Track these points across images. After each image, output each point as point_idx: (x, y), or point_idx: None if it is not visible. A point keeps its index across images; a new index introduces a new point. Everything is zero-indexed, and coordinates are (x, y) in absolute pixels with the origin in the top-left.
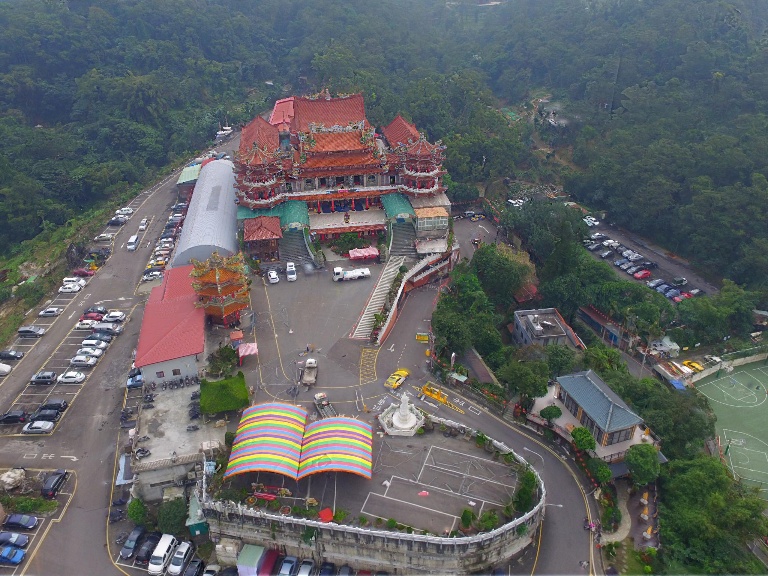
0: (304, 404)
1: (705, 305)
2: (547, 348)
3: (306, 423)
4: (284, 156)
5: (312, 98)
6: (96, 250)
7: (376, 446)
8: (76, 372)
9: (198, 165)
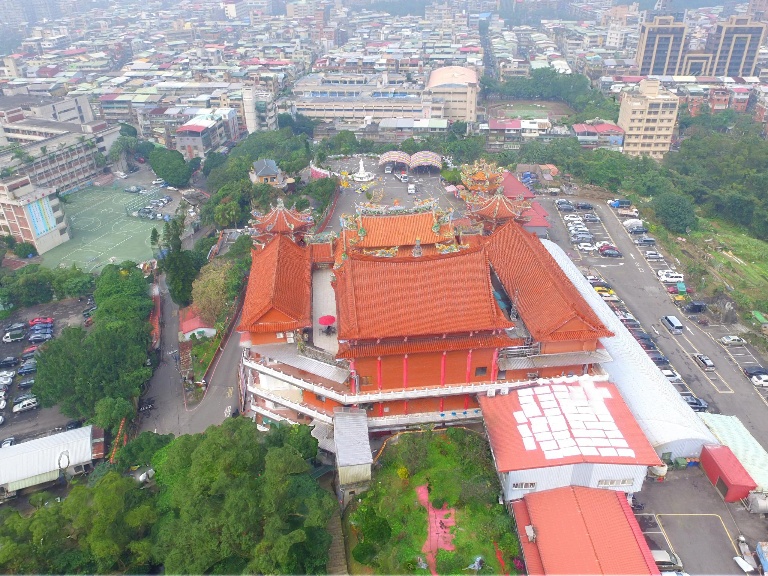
0: (414, 182)
1: (76, 269)
2: (269, 188)
3: (411, 177)
4: (473, 231)
5: (451, 251)
6: (698, 303)
7: (378, 171)
8: (571, 216)
9: (766, 486)
